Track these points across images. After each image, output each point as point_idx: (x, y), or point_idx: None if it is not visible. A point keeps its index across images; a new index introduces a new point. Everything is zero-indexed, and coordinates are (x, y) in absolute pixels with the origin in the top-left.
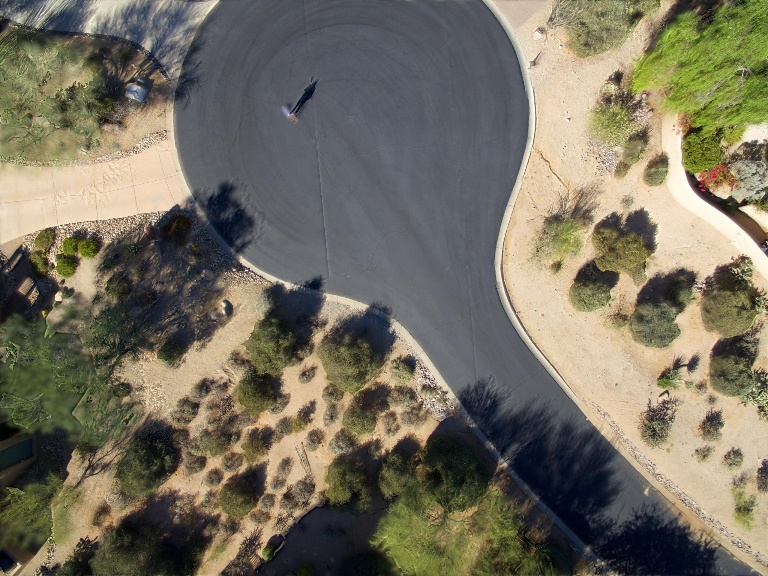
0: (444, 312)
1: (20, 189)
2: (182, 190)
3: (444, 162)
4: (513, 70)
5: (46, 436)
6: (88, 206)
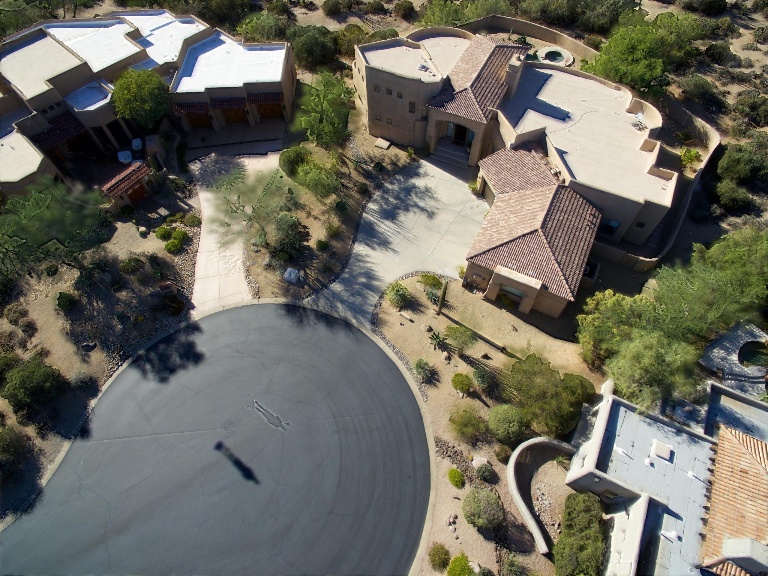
0: None
1: None
2: (207, 310)
3: None
4: None
5: (47, 224)
6: (211, 246)
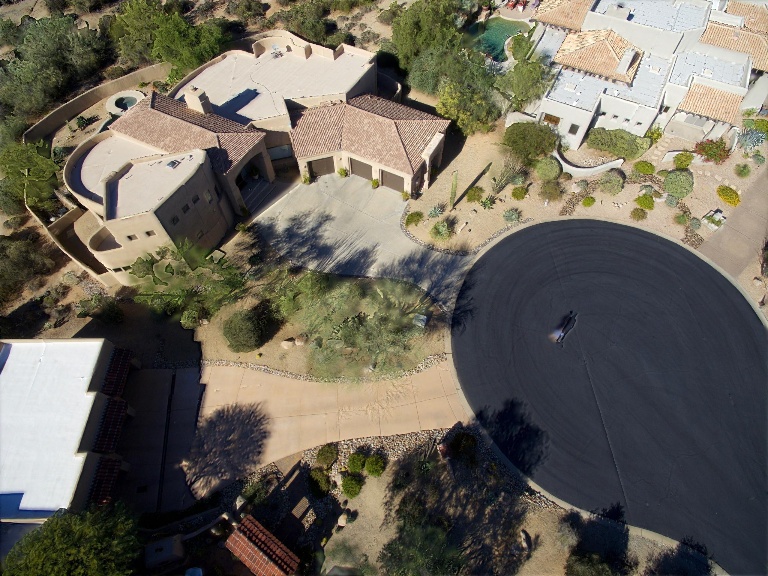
0: (766, 552)
1: (304, 404)
2: (463, 407)
3: (712, 386)
4: (746, 308)
5: None
6: (372, 421)
